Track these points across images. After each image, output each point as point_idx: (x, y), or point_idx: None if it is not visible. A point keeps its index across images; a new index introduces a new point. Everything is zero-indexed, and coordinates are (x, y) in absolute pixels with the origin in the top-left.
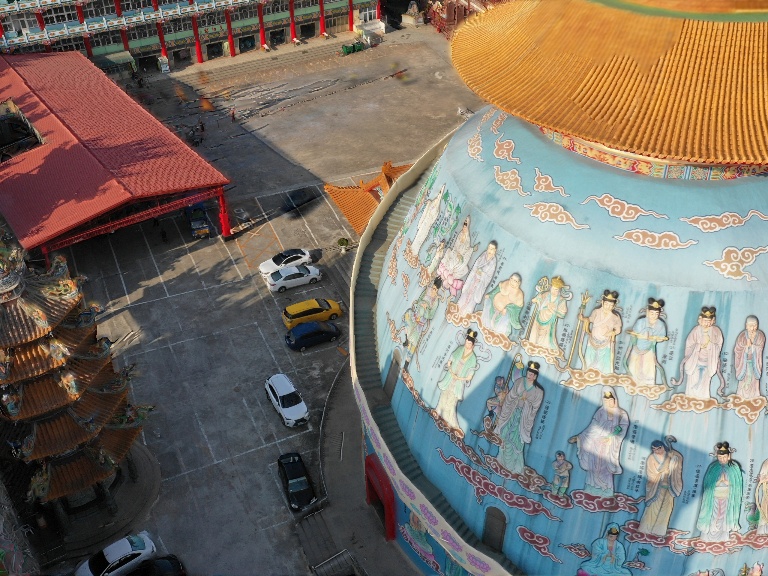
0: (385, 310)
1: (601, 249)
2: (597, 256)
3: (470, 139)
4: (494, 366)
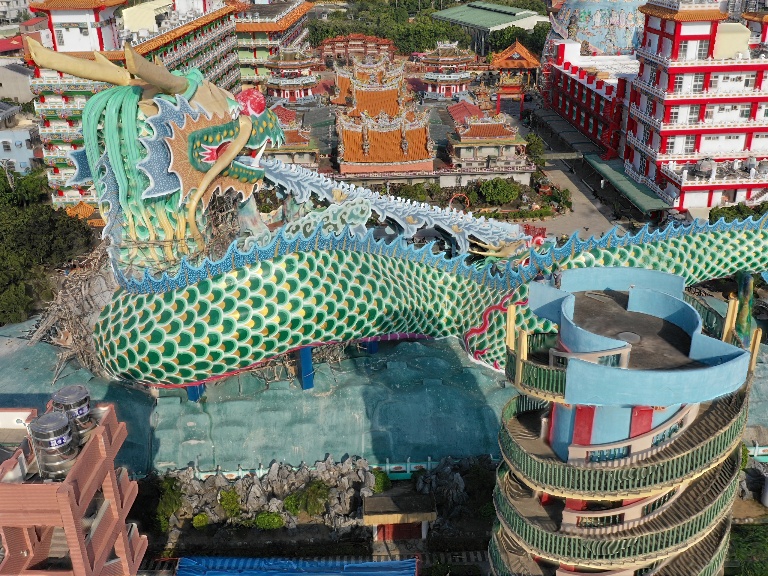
0: (596, 42)
1: (639, 3)
2: (639, 4)
3: None
4: (635, 30)
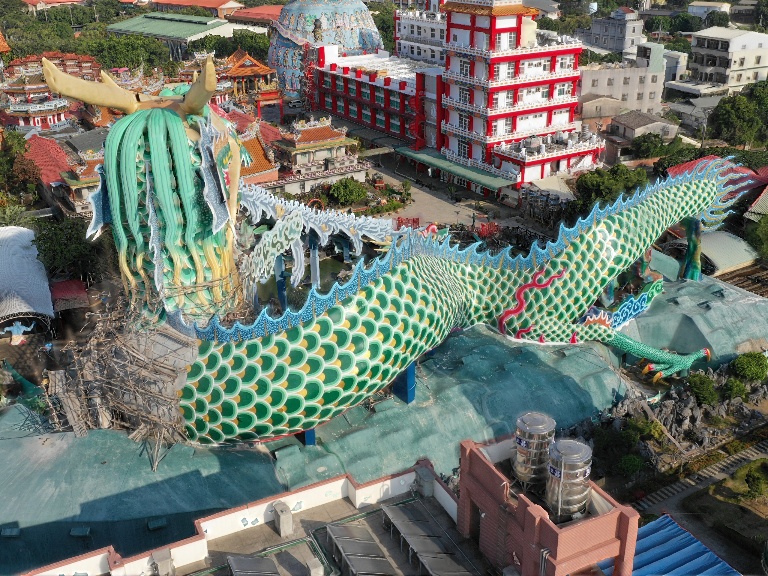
0: None
1: None
2: None
3: (315, 6)
4: None
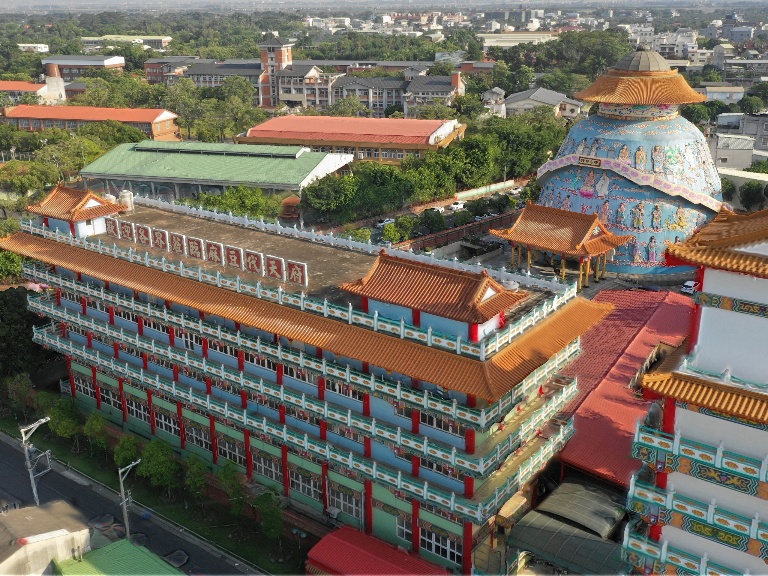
0: None
1: None
2: None
3: (670, 134)
4: None
